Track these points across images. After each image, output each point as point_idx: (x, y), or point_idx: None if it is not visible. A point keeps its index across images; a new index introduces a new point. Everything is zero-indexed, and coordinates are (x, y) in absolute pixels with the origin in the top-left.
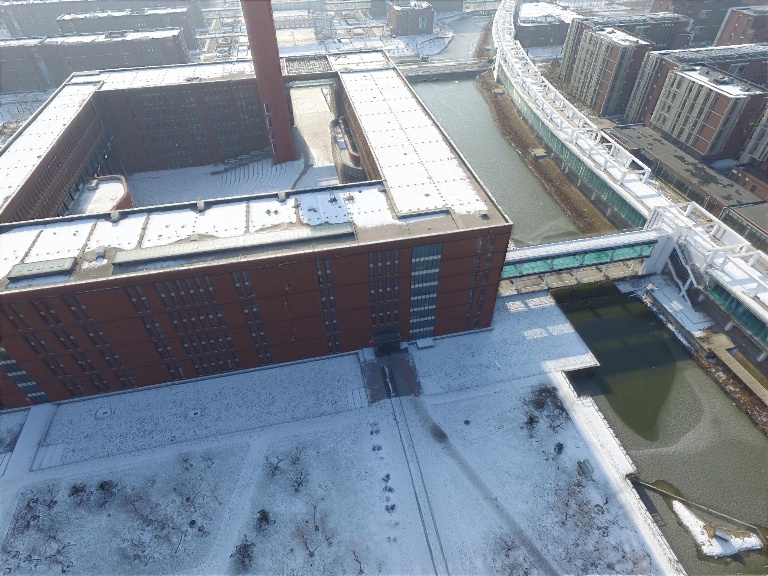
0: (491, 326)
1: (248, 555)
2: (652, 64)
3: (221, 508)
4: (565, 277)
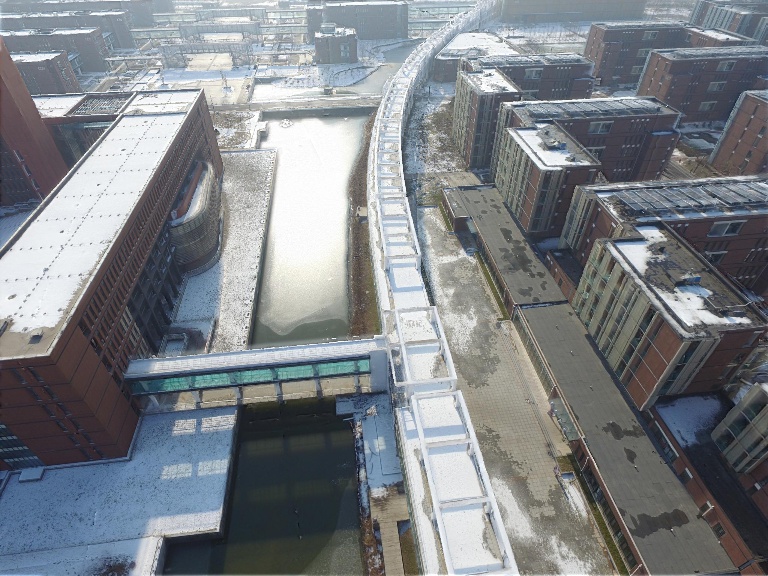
0: (127, 456)
1: None
2: (504, 117)
3: None
4: (269, 389)
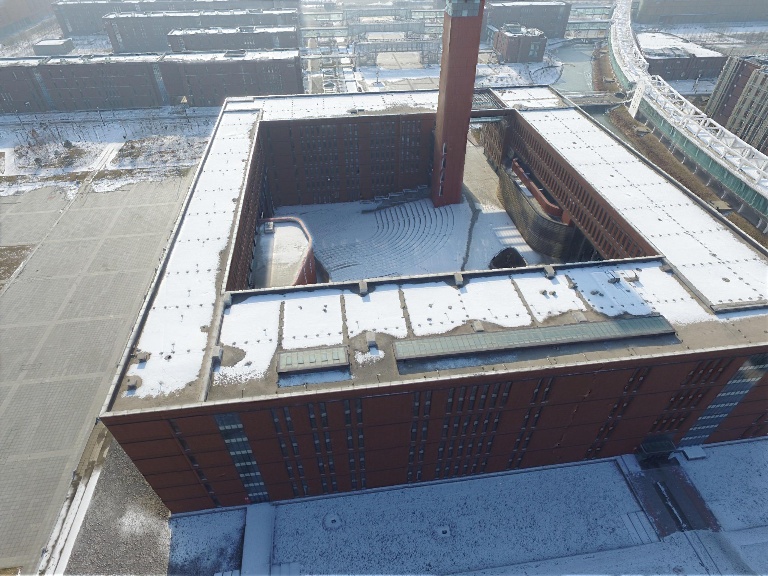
0: None
1: None
2: None
3: None
4: None
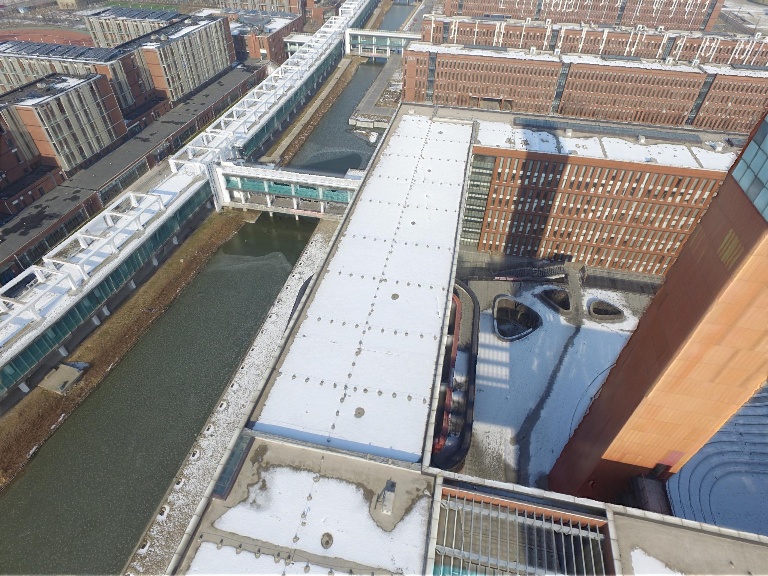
0: None
1: None
2: None
3: None
4: (305, 207)
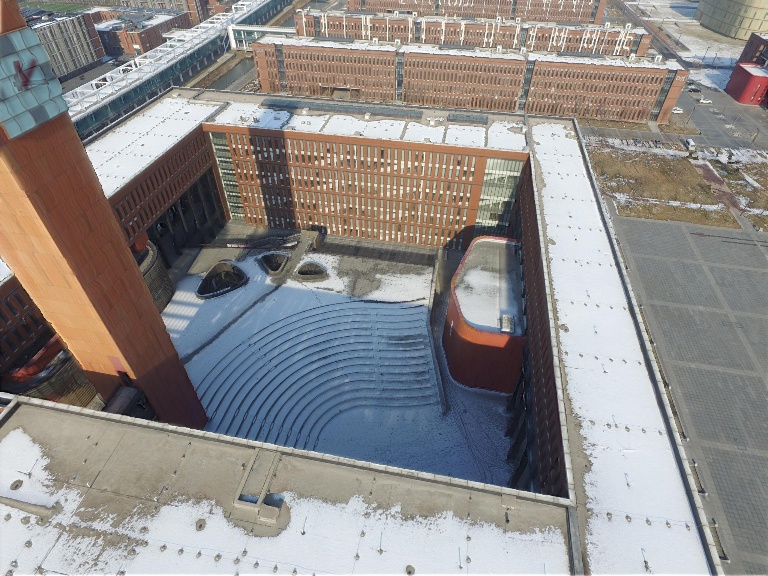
0: None
1: None
2: None
3: None
4: None
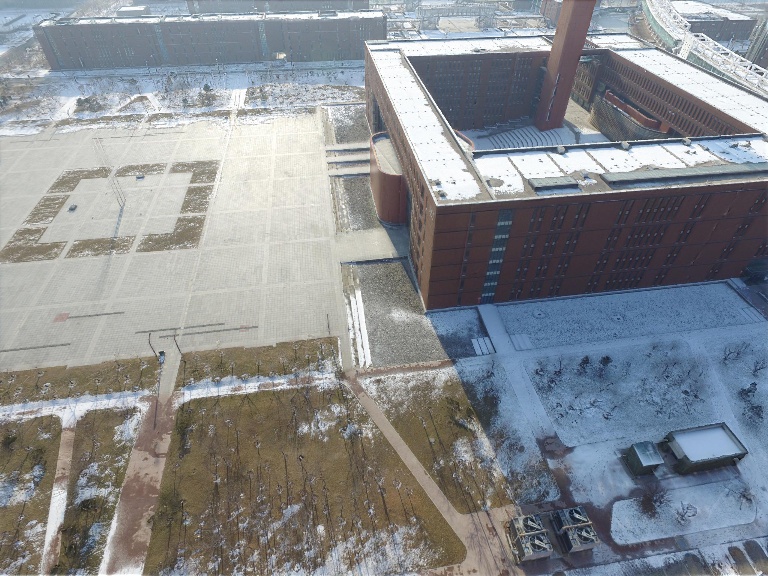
0: None
1: (760, 414)
2: None
3: (699, 384)
4: None
